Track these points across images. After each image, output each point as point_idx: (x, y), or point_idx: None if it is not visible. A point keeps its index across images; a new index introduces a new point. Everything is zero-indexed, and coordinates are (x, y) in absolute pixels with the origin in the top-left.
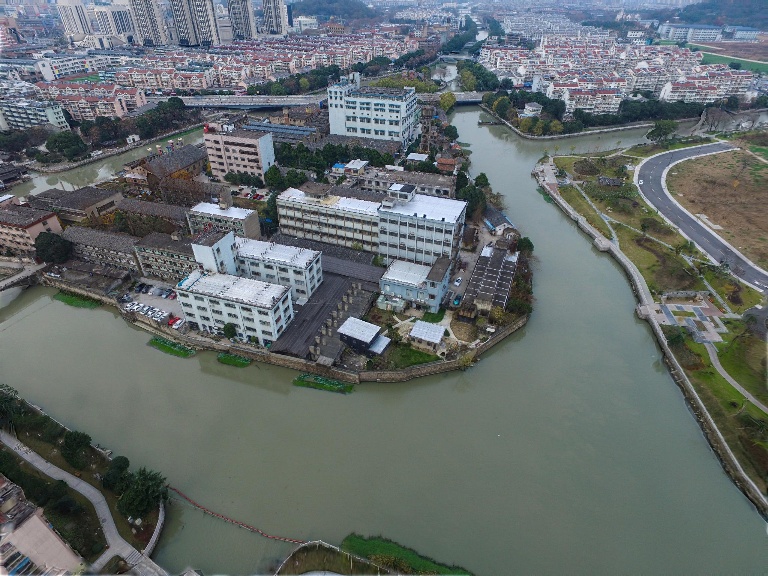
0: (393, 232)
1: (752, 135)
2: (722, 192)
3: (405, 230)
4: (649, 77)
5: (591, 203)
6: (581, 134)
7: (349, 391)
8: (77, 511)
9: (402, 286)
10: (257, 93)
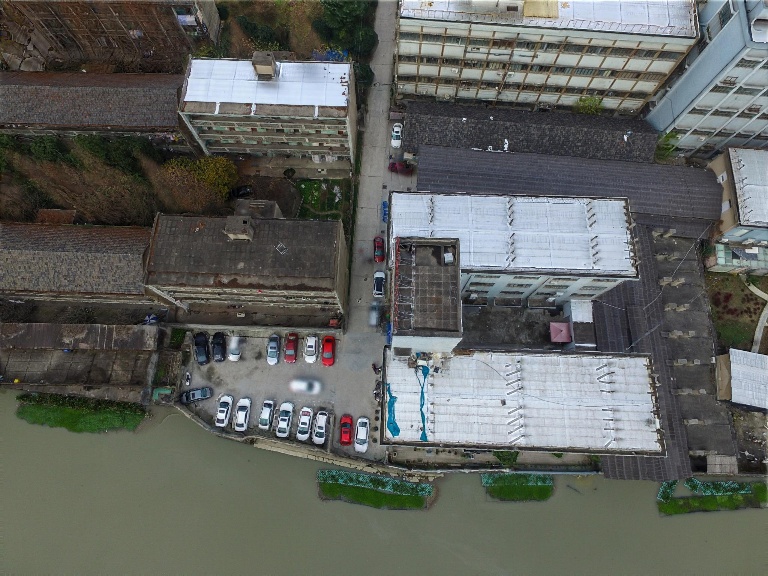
0: (752, 88)
1: None
2: None
3: None
4: None
5: None
6: None
7: (767, 499)
8: None
9: None
10: None
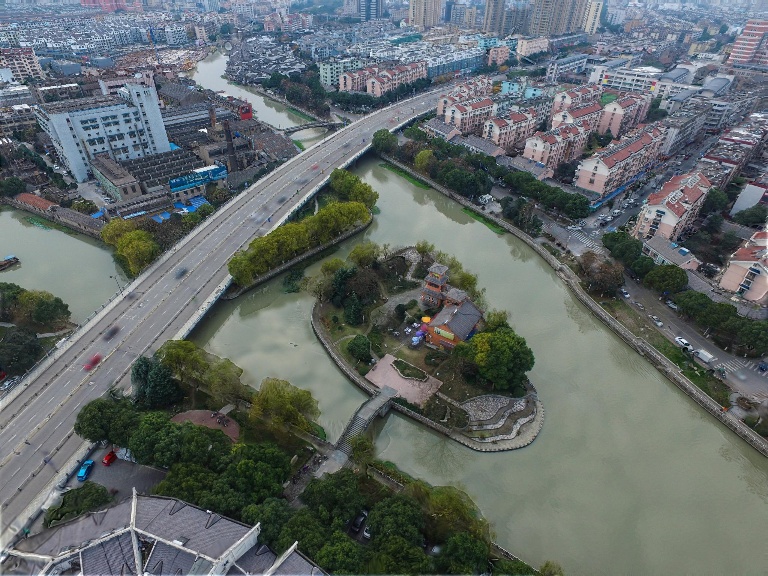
0: None
1: None
2: None
3: None
4: None
5: None
6: None
7: None
8: None
9: None
10: (408, 137)
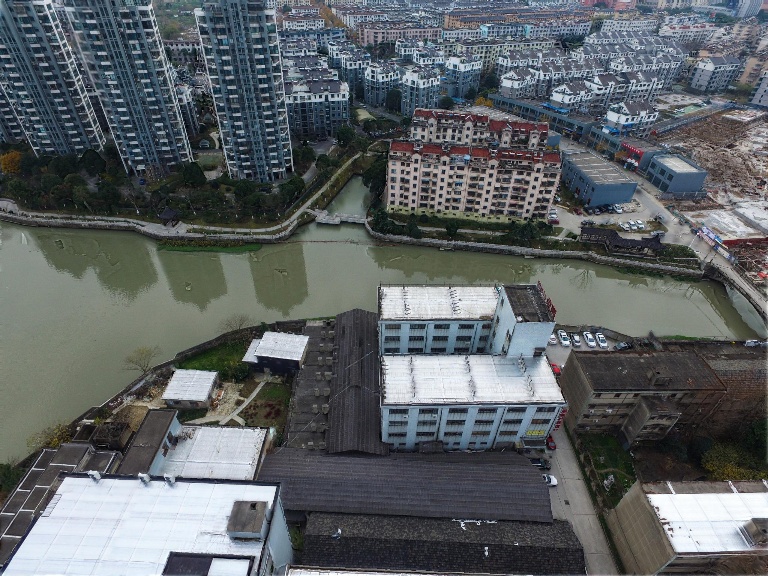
0: None
1: None
2: None
3: None
4: None
5: None
6: None
7: None
8: None
9: None
10: None
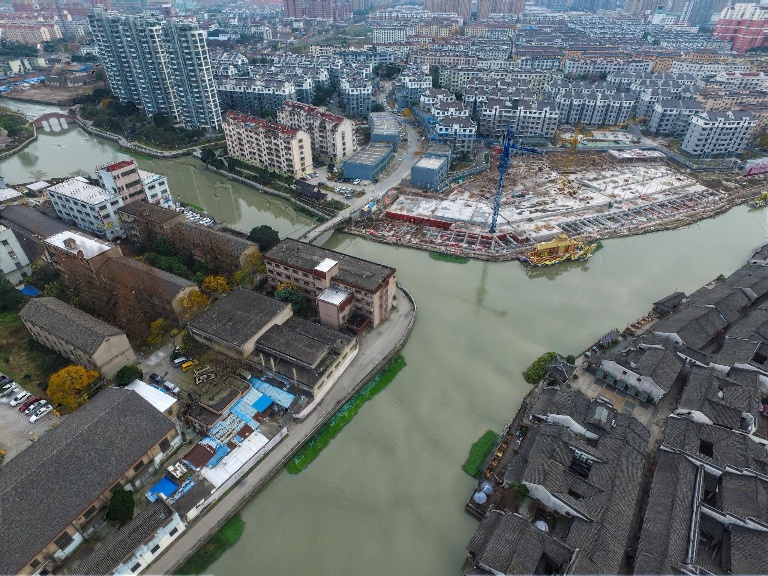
0: None
1: None
2: None
3: None
4: None
5: None
6: None
7: None
8: (231, 157)
9: None
10: None
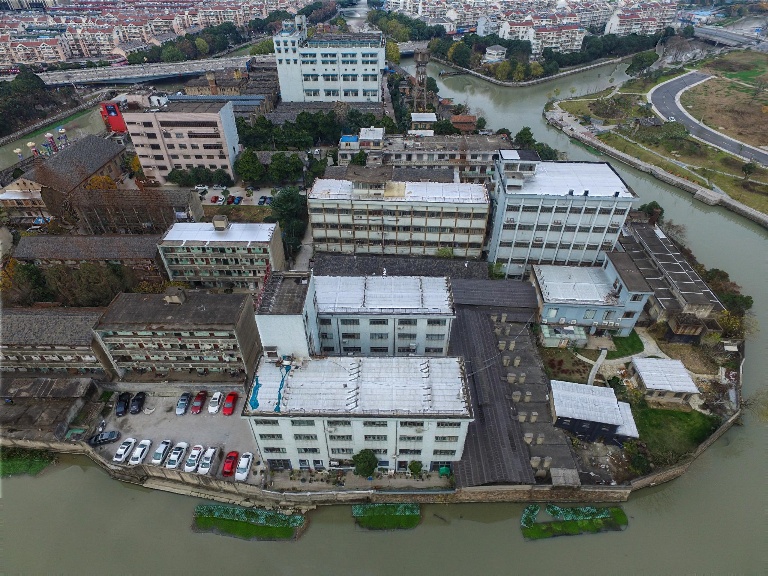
0: (527, 224)
1: (712, 62)
2: (753, 120)
3: (547, 218)
4: (585, 13)
5: (647, 149)
6: (557, 76)
7: (626, 522)
8: None
9: (583, 307)
10: (142, 61)
